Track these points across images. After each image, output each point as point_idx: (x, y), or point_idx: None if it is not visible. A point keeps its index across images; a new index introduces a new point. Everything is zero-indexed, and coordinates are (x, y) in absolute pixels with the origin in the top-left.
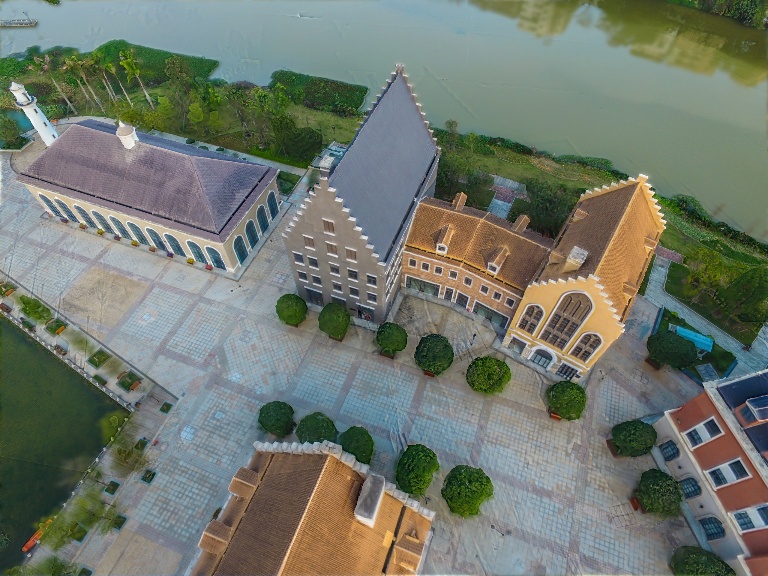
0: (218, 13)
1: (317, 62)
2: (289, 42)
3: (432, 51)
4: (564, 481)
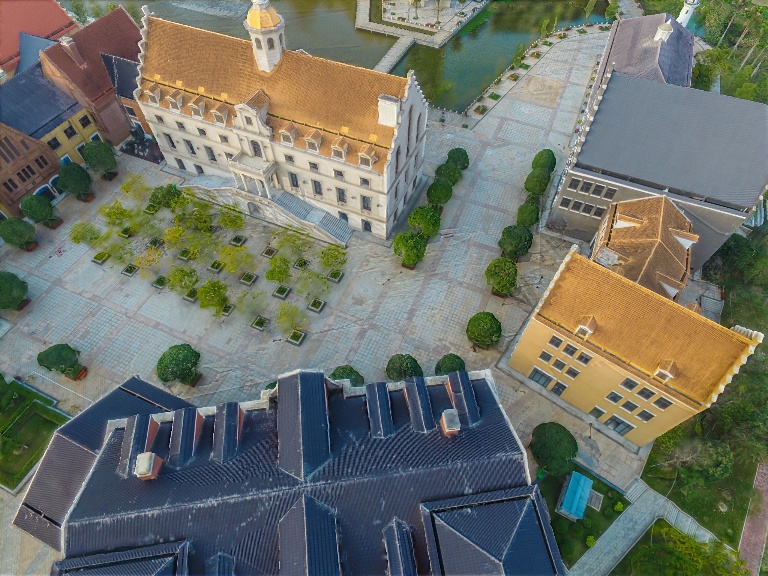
0: None
1: None
2: None
3: None
4: (419, 332)
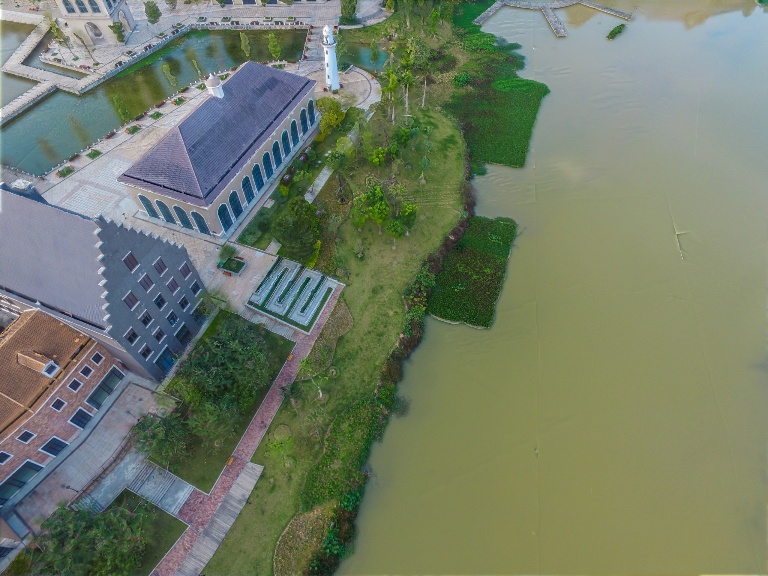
0: (645, 151)
1: (547, 262)
2: (593, 227)
3: (636, 436)
4: None
